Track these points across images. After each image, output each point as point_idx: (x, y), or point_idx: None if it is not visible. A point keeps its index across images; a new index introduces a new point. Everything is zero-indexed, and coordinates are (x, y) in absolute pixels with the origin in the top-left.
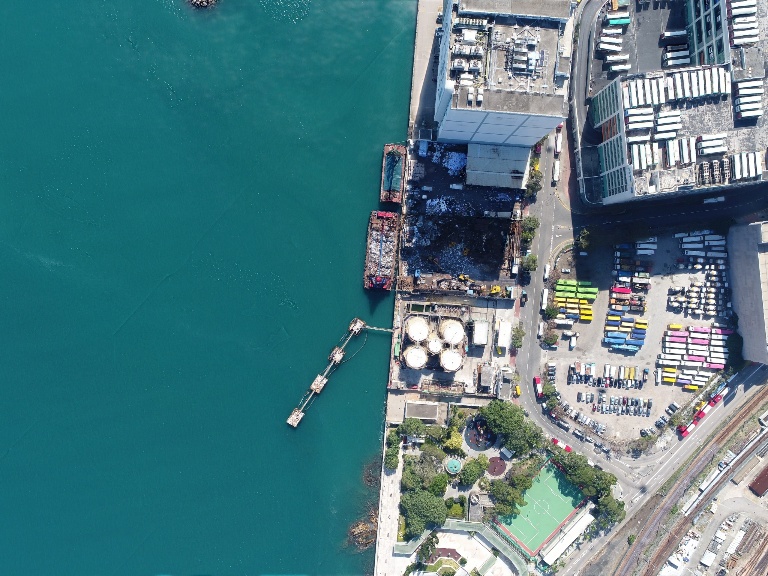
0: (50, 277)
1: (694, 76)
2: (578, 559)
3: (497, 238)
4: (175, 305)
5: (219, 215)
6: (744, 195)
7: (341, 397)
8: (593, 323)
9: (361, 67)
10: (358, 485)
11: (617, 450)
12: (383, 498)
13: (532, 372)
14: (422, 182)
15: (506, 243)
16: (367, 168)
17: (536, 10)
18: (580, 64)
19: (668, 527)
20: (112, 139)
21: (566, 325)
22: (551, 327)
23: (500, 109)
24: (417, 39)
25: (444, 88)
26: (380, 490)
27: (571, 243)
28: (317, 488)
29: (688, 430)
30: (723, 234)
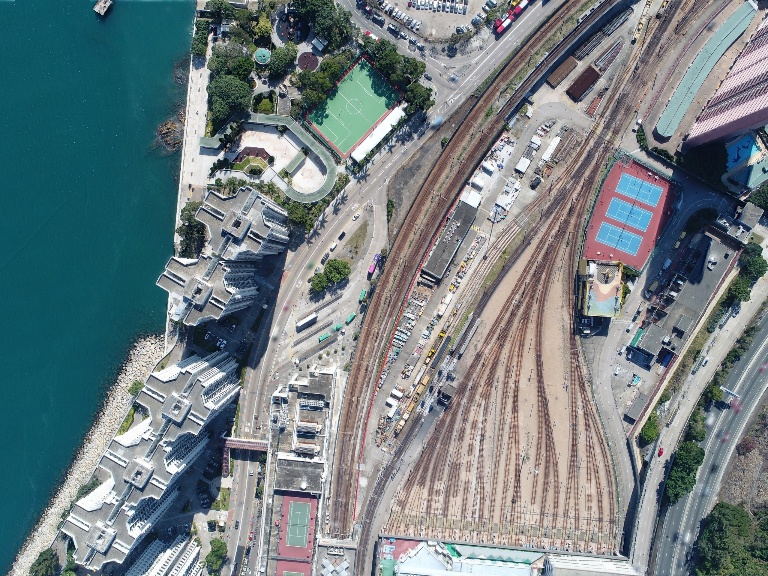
0: None
1: None
2: (390, 163)
3: None
4: None
5: None
6: None
7: None
8: None
9: None
10: (168, 84)
11: (432, 48)
12: (191, 93)
13: None
14: None
15: None
16: None
17: None
18: None
19: (481, 128)
20: None
21: None
22: None
23: None
24: None
25: None
26: (188, 84)
27: None
28: (126, 86)
29: (503, 25)
30: None
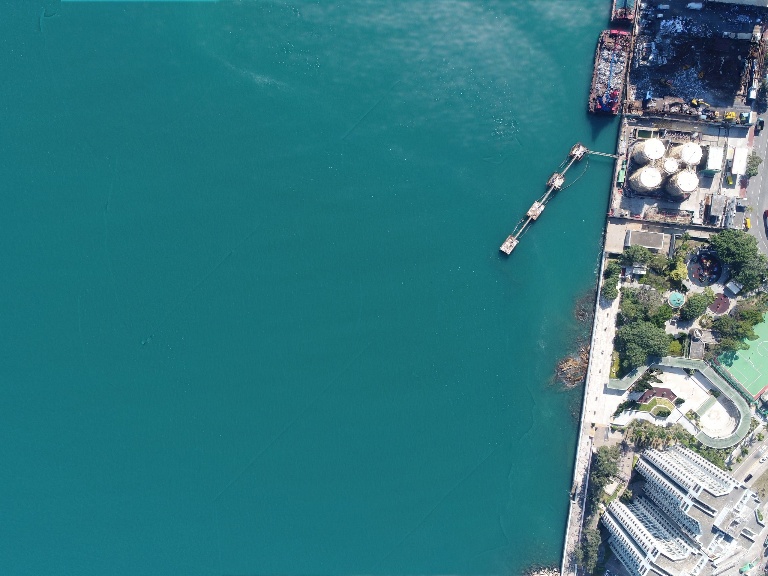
0: (262, 96)
1: None
2: None
3: (734, 62)
4: (406, 111)
5: (456, 19)
6: None
7: (558, 225)
8: None
9: None
10: (568, 320)
11: None
12: (597, 332)
13: (763, 205)
14: (657, 1)
15: (745, 66)
16: None
17: None
18: None
19: None
20: None
21: None
22: None
23: None
24: None
25: None
26: (594, 323)
27: None
28: (525, 321)
29: None
30: None
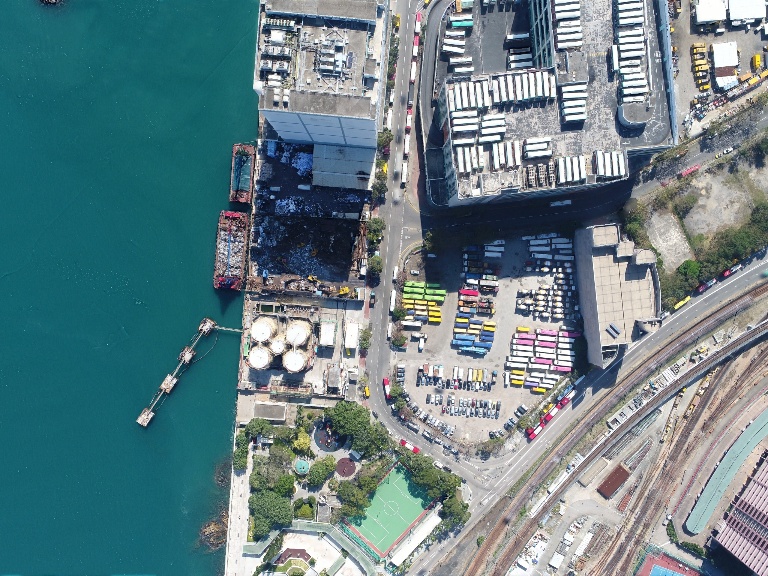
0: None
1: (518, 79)
2: (428, 560)
3: (346, 239)
4: (14, 304)
5: (58, 213)
6: (593, 198)
7: (191, 397)
8: (442, 325)
9: (211, 66)
10: (210, 485)
11: (466, 452)
12: (233, 498)
13: (382, 373)
14: (271, 182)
15: (354, 244)
16: (217, 168)
17: (342, 11)
18: (427, 66)
19: (516, 529)
20: None
21: (415, 327)
22: (398, 329)
23: (307, 110)
24: None
25: None
26: (230, 490)
27: (420, 245)
28: (169, 488)
29: (535, 432)
30: (569, 237)
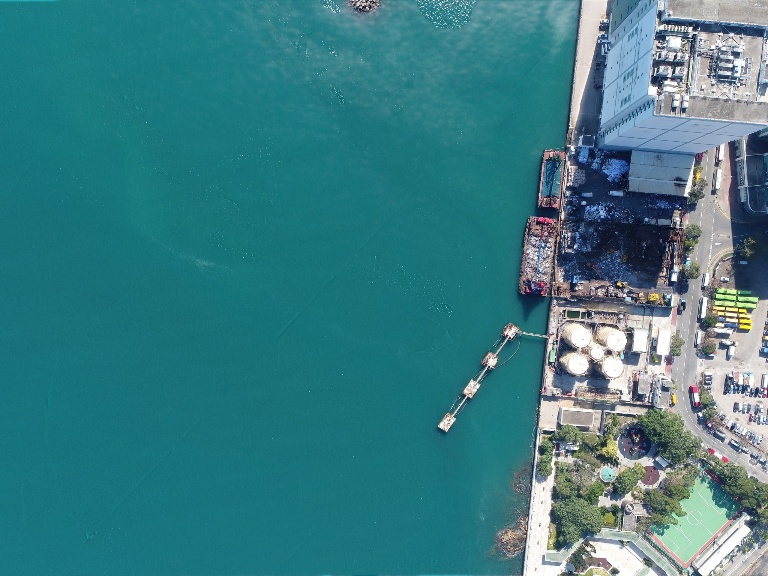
0: (202, 277)
1: None
2: (731, 571)
3: (656, 245)
4: (340, 307)
5: (386, 218)
6: None
7: (493, 403)
8: (751, 333)
9: (521, 73)
10: (507, 492)
11: None
12: (534, 505)
13: (688, 381)
14: (581, 188)
15: (666, 251)
16: (525, 174)
17: (743, 18)
18: None
19: None
20: (283, 141)
21: (724, 334)
22: (711, 336)
23: (704, 116)
24: (579, 46)
25: (644, 94)
26: (531, 497)
27: (730, 252)
28: (465, 494)
29: None
30: None
